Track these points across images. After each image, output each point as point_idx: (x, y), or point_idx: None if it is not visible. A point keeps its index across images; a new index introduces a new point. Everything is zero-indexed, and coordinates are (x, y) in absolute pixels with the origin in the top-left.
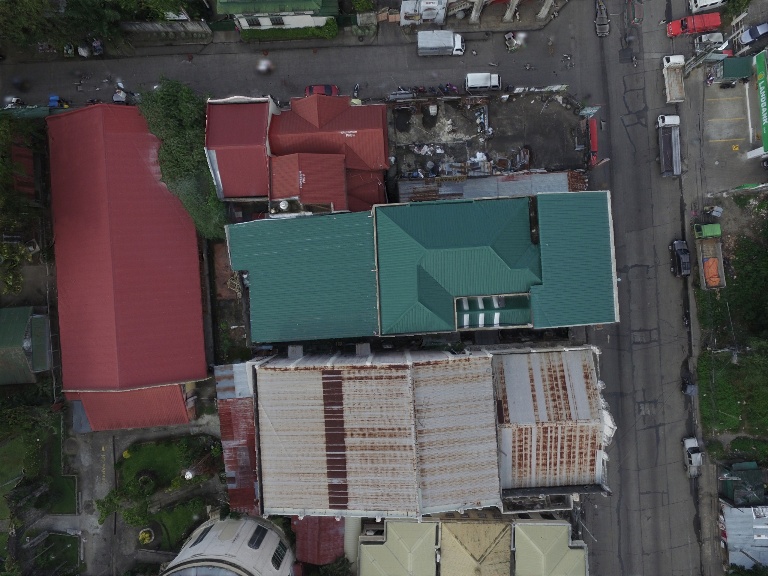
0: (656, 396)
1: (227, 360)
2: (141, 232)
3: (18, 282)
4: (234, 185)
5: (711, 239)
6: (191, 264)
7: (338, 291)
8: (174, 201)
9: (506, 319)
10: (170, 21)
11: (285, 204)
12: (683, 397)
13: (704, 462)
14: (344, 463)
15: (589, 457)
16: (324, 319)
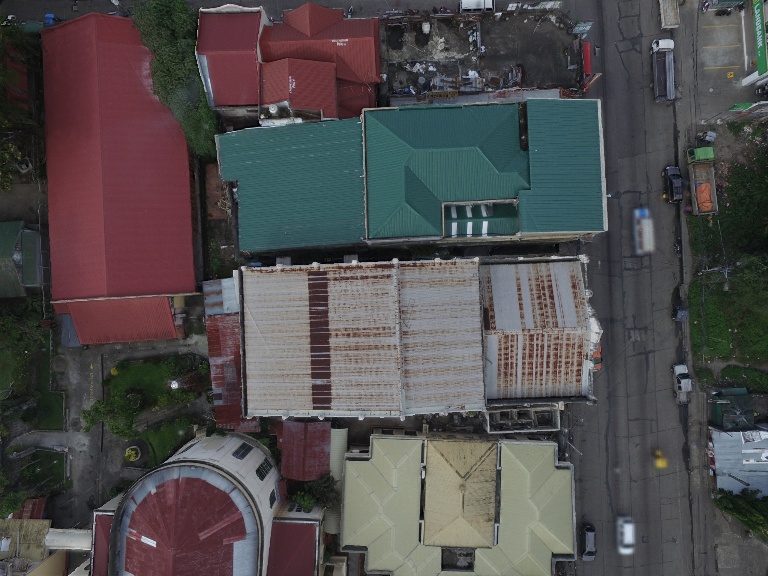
0: (646, 323)
1: None
2: (132, 143)
3: (7, 180)
4: (224, 93)
5: (704, 164)
6: (181, 178)
7: (326, 198)
8: (165, 114)
9: (494, 229)
10: None
11: (274, 108)
12: (674, 324)
13: (694, 390)
14: (328, 363)
15: (575, 367)
16: (312, 226)
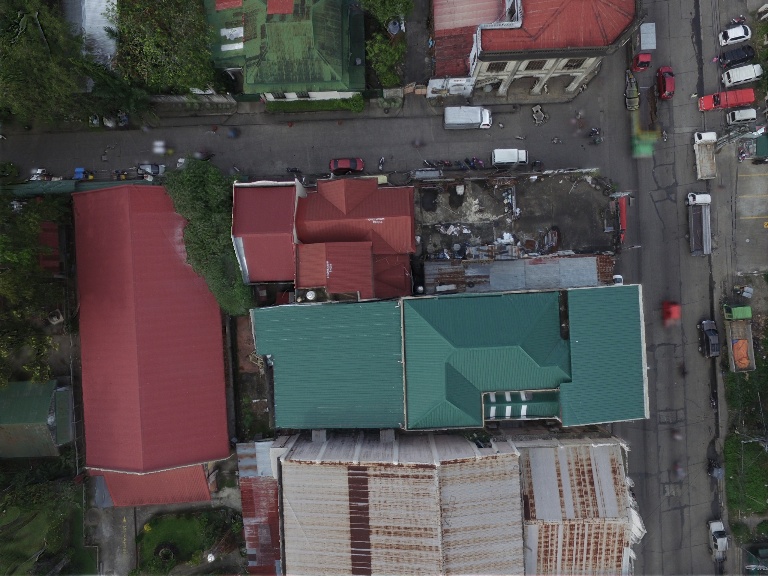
0: (681, 477)
1: (249, 434)
2: (166, 312)
3: (45, 371)
4: (260, 270)
5: (741, 320)
6: (215, 342)
7: (364, 380)
8: (198, 279)
9: (533, 411)
10: (195, 94)
11: (312, 295)
12: (709, 479)
13: (730, 545)
14: (369, 560)
15: (616, 554)
16: (349, 408)
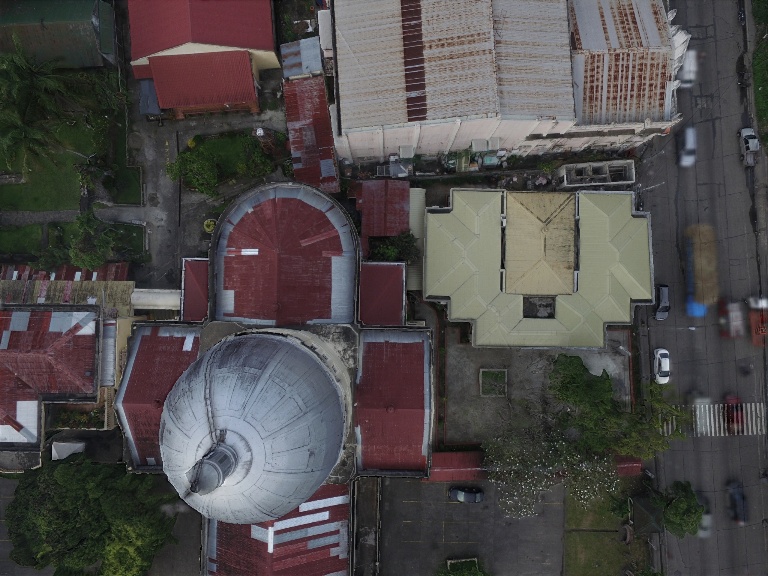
0: (712, 90)
1: None
2: None
3: None
4: None
5: None
6: None
7: None
8: None
9: None
10: None
11: None
12: (739, 92)
13: (760, 154)
14: (423, 75)
15: (659, 90)
16: None
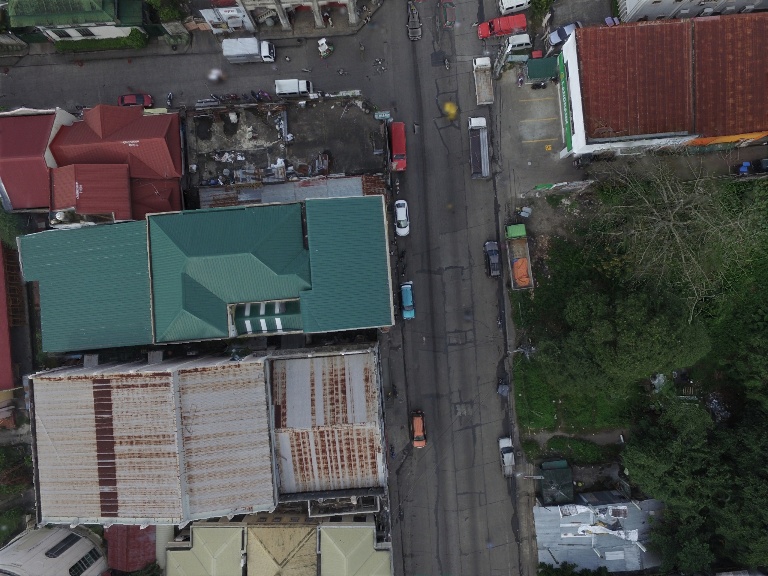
0: (472, 397)
1: None
2: None
3: None
4: (21, 197)
5: (520, 239)
6: None
7: (121, 300)
8: None
9: (288, 324)
10: None
11: (60, 215)
12: (499, 397)
13: (521, 461)
14: (114, 471)
15: (369, 460)
16: (108, 328)
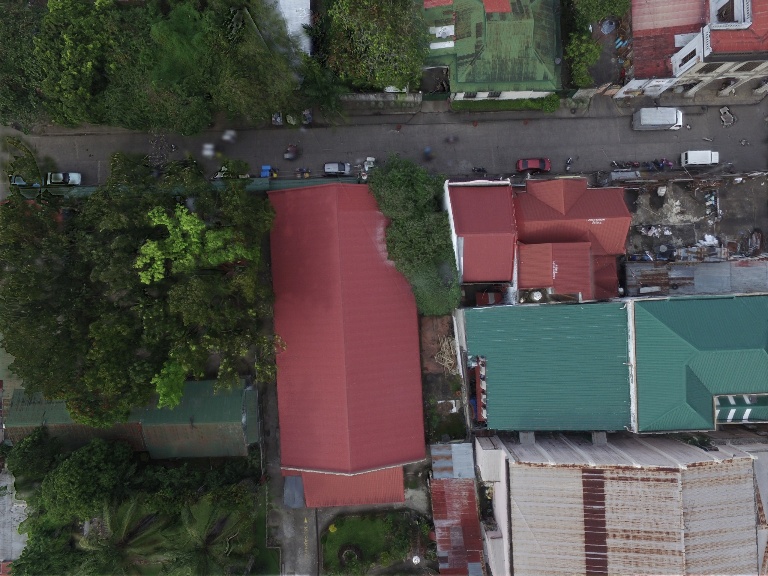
0: None
1: (434, 435)
2: (370, 312)
3: (273, 370)
4: (475, 270)
5: None
6: (412, 342)
7: (585, 382)
8: (398, 279)
9: (756, 415)
10: (387, 93)
11: (540, 295)
12: None
13: None
14: (605, 564)
15: None
16: (569, 410)
